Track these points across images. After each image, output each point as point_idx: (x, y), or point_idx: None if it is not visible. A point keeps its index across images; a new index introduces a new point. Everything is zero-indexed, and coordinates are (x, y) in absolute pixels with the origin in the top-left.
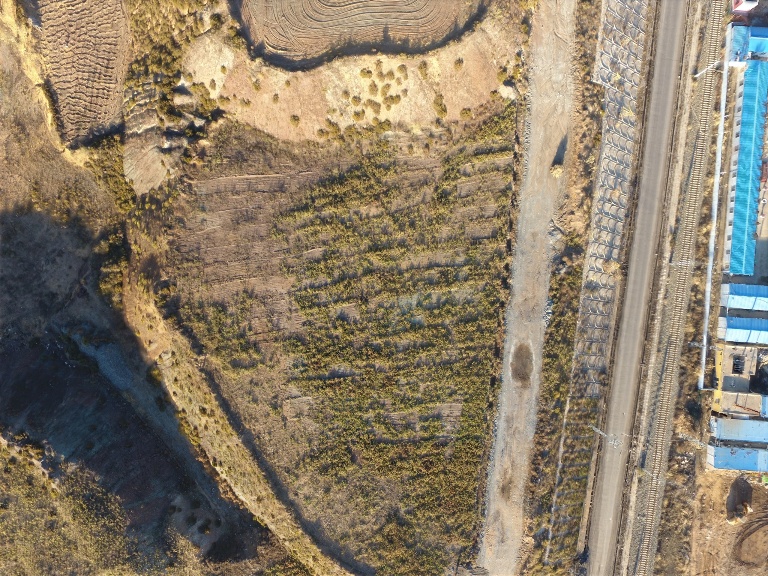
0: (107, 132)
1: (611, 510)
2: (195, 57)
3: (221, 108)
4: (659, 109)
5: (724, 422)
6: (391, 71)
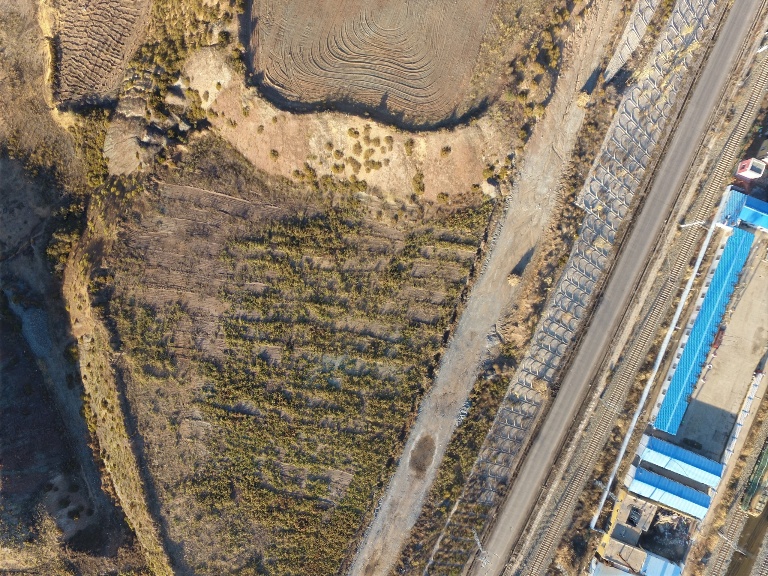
0: (99, 104)
1: None
2: (196, 65)
3: (209, 120)
4: (636, 246)
5: (603, 567)
6: (378, 138)
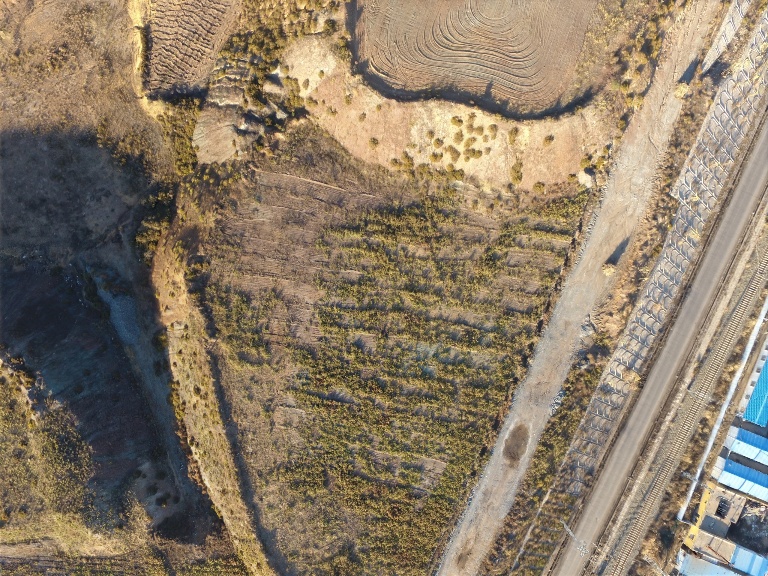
0: (189, 93)
1: None
2: (298, 53)
3: (306, 108)
4: (724, 238)
5: (692, 559)
6: (482, 127)
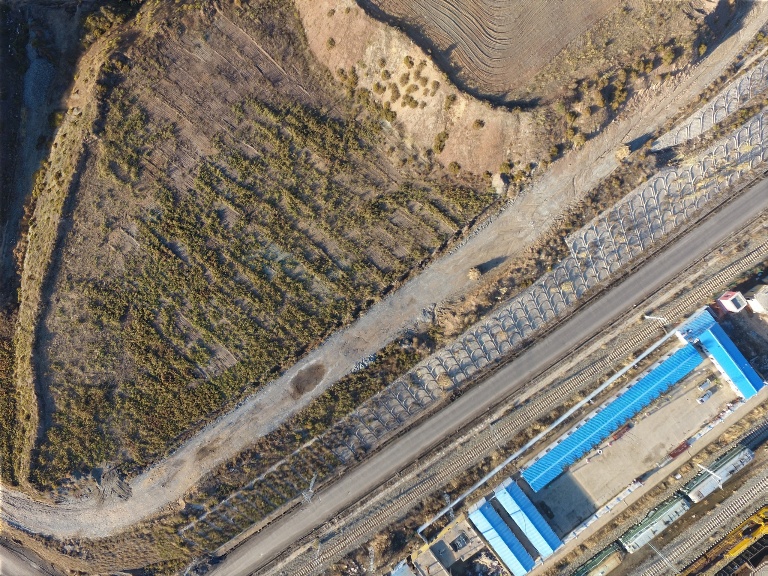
0: None
1: (269, 548)
2: None
3: None
4: (597, 312)
5: (408, 571)
6: (427, 78)
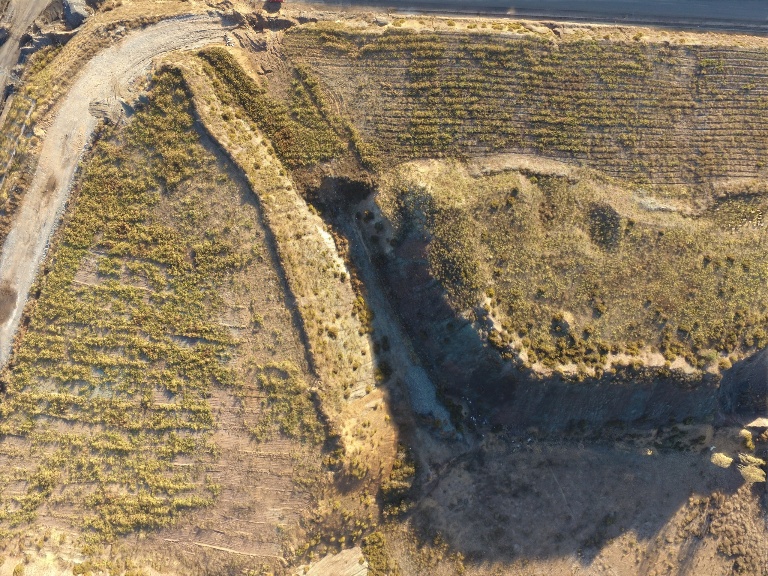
0: None
1: None
2: None
3: None
4: None
5: None
6: None
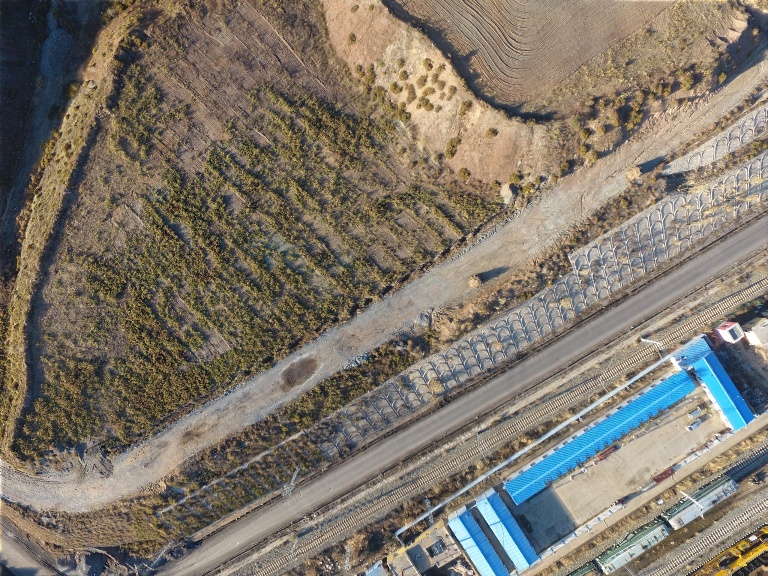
0: None
1: (245, 538)
2: None
3: None
4: (594, 331)
5: (382, 572)
6: (445, 82)
